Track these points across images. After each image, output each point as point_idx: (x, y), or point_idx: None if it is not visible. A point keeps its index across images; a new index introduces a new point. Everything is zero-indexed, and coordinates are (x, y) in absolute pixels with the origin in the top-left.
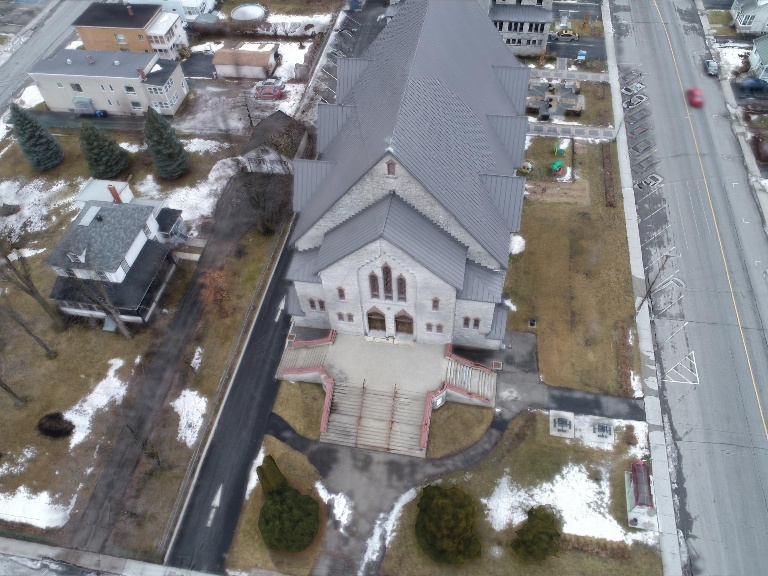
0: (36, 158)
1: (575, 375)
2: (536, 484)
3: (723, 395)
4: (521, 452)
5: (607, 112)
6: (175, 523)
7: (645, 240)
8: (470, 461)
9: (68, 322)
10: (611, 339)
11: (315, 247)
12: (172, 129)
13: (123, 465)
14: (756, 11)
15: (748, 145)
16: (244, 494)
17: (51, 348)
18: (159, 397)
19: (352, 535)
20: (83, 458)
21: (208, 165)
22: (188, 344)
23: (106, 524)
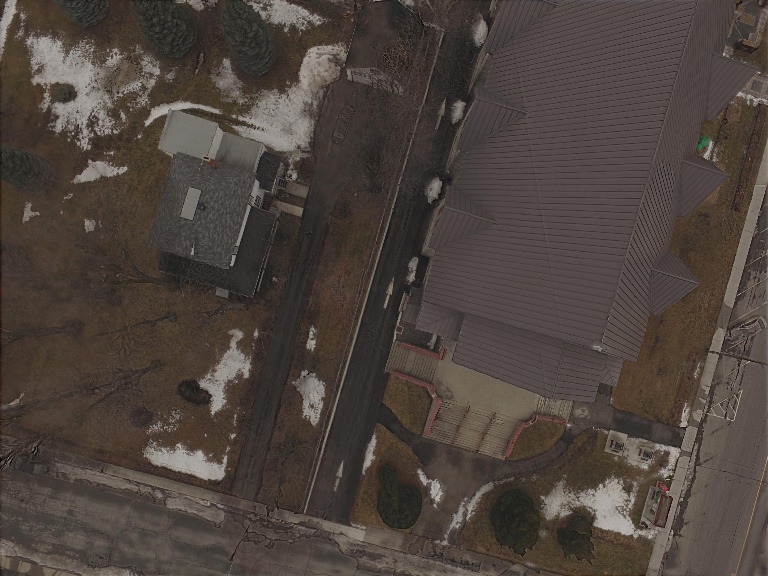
0: (75, 15)
1: (640, 402)
2: (584, 489)
3: (748, 433)
4: (579, 463)
5: None
6: (309, 487)
7: (751, 260)
8: (538, 466)
9: (179, 281)
10: (681, 371)
11: None
12: (256, 17)
13: (260, 435)
14: None
15: None
16: (361, 470)
17: (169, 309)
18: (282, 375)
19: (443, 510)
20: (225, 425)
21: (297, 54)
22: (302, 322)
23: (255, 481)
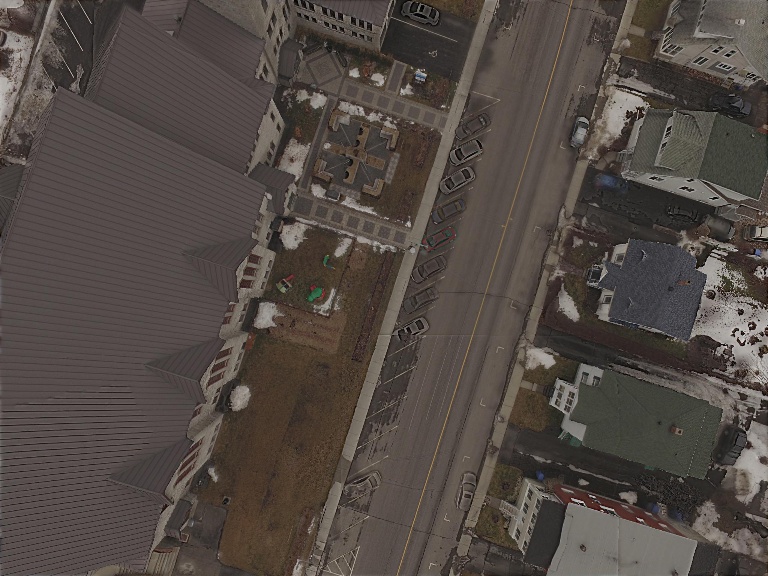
0: None
1: (248, 558)
2: None
3: None
4: None
5: (415, 195)
6: None
7: (373, 412)
8: None
9: None
10: (293, 526)
11: None
12: None
13: None
14: (686, 45)
15: (546, 290)
16: None
17: None
18: None
19: None
20: None
21: None
22: None
23: None
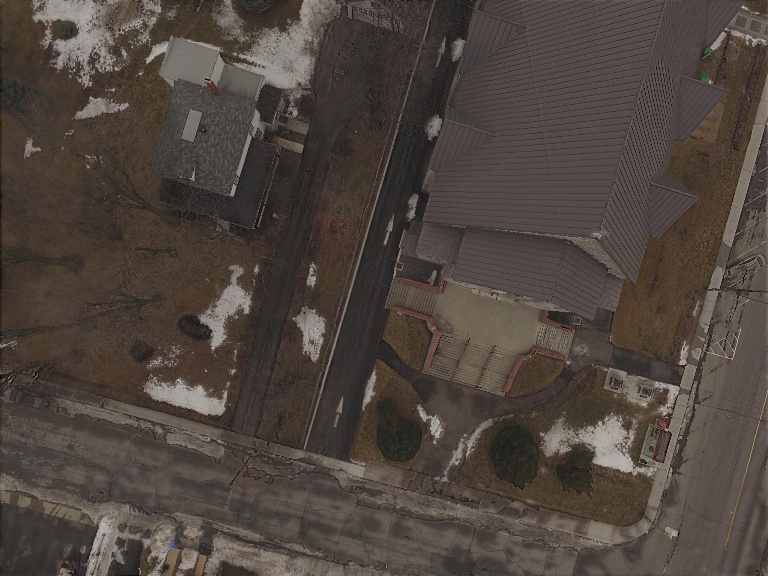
0: None
1: (639, 339)
2: (583, 426)
3: (747, 372)
4: (578, 401)
5: None
6: (309, 423)
7: (750, 199)
8: (538, 403)
9: (179, 216)
10: (680, 309)
11: (450, 226)
12: None
13: (260, 371)
14: None
15: None
16: (361, 406)
17: (169, 244)
18: (282, 311)
19: (442, 446)
20: (225, 361)
21: None
22: (302, 258)
23: (255, 417)
